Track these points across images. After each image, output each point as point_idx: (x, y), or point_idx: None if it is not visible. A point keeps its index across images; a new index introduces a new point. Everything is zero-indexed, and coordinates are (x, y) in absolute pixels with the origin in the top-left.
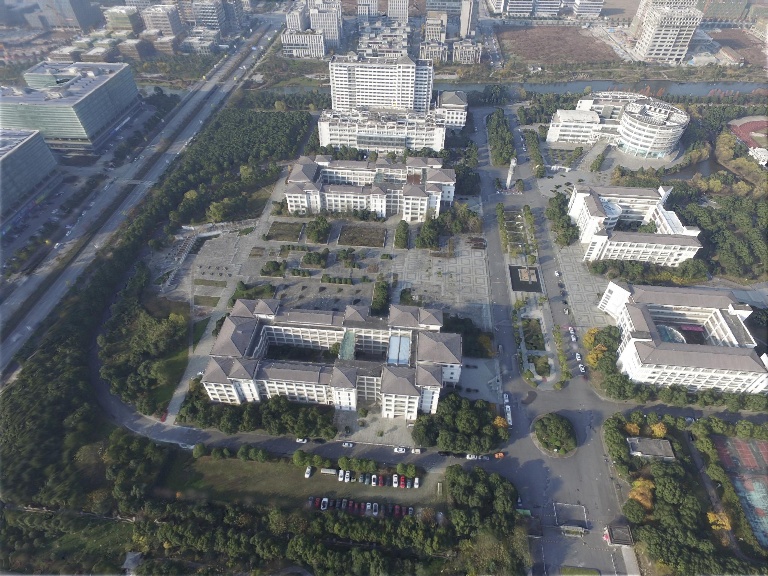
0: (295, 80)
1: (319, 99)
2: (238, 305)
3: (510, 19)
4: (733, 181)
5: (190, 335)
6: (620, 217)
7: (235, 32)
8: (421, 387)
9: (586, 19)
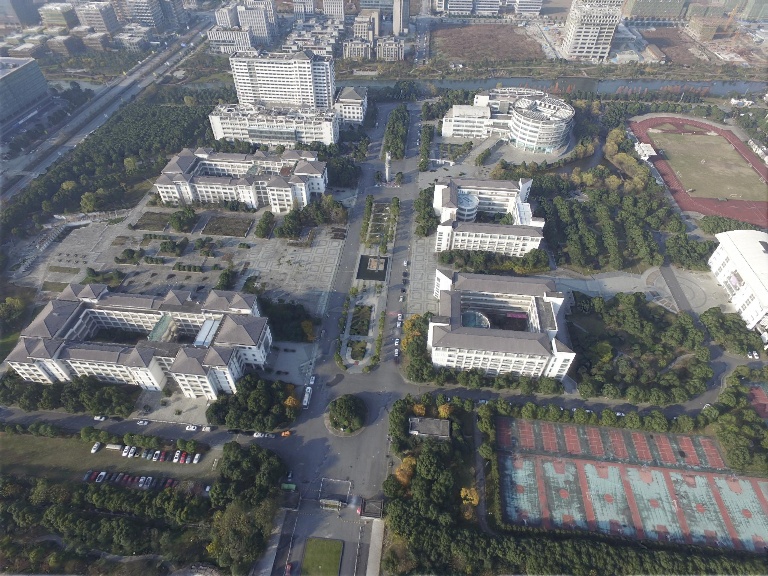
0: (216, 76)
1: (231, 94)
2: (67, 289)
3: (450, 17)
4: (609, 175)
5: (27, 319)
6: (484, 209)
7: (173, 29)
8: (210, 367)
9: (525, 17)
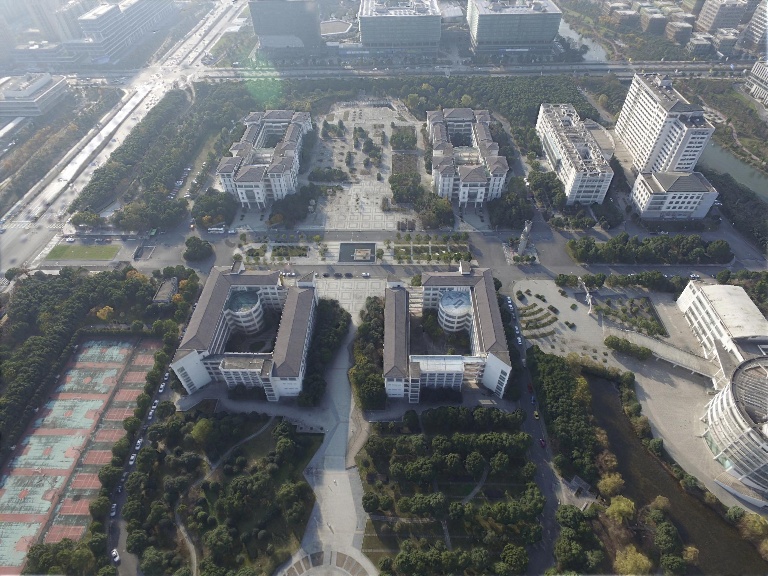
0: None
1: None
2: None
3: None
4: (669, 570)
5: None
6: None
7: None
8: None
9: None
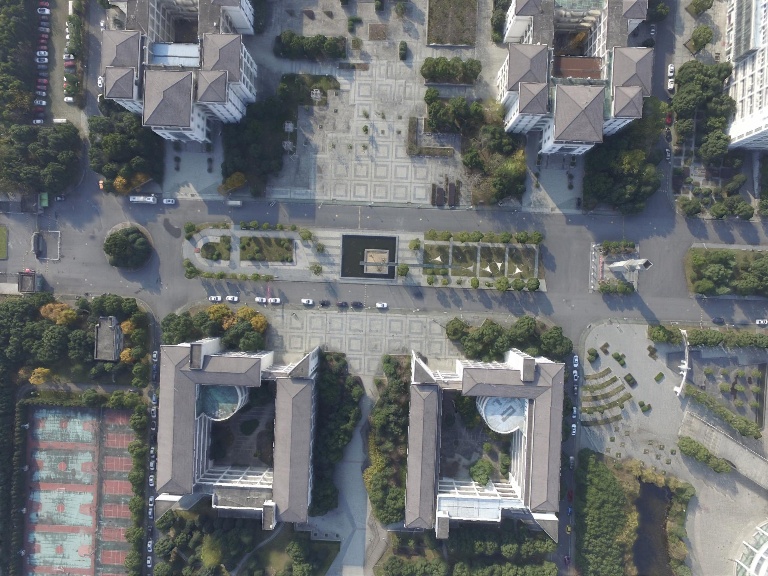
0: None
1: None
2: None
3: None
4: None
5: None
6: None
7: None
8: None
9: None
